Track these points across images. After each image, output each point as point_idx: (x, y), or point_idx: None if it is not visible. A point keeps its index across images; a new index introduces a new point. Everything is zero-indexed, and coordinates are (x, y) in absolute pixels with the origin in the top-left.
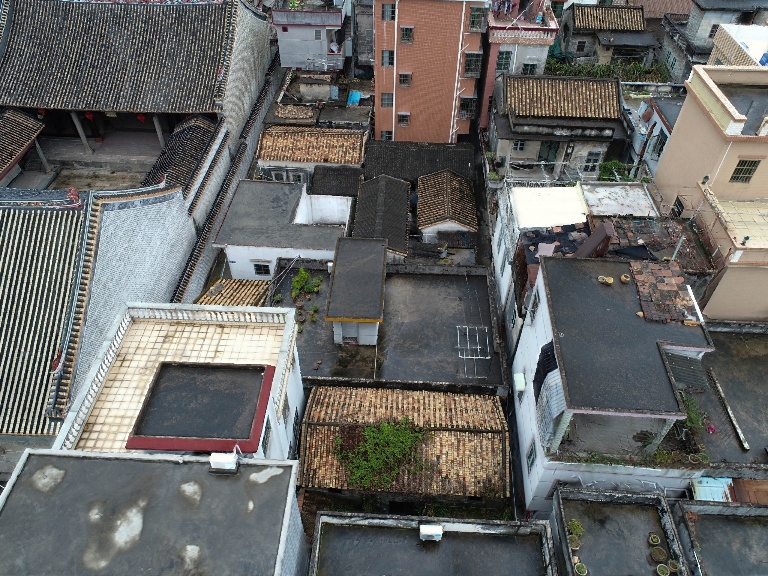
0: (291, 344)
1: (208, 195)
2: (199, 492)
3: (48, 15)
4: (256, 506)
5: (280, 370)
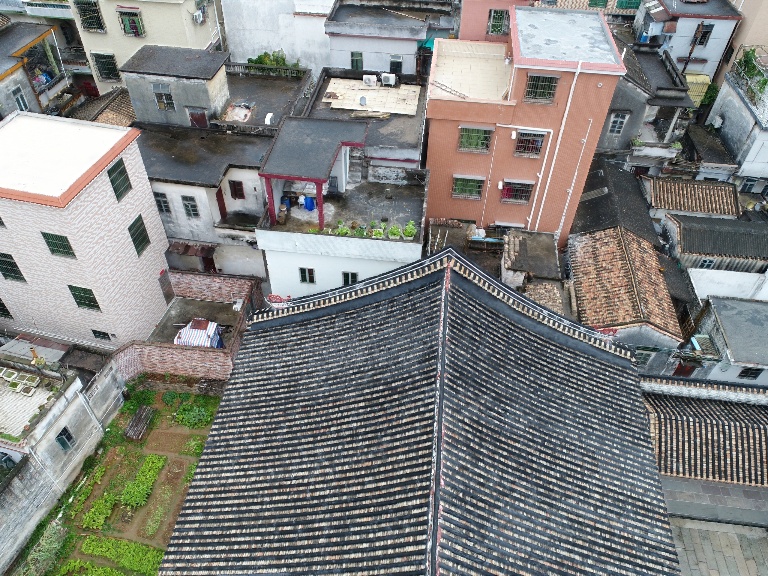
0: None
1: None
2: None
3: None
4: None
5: None
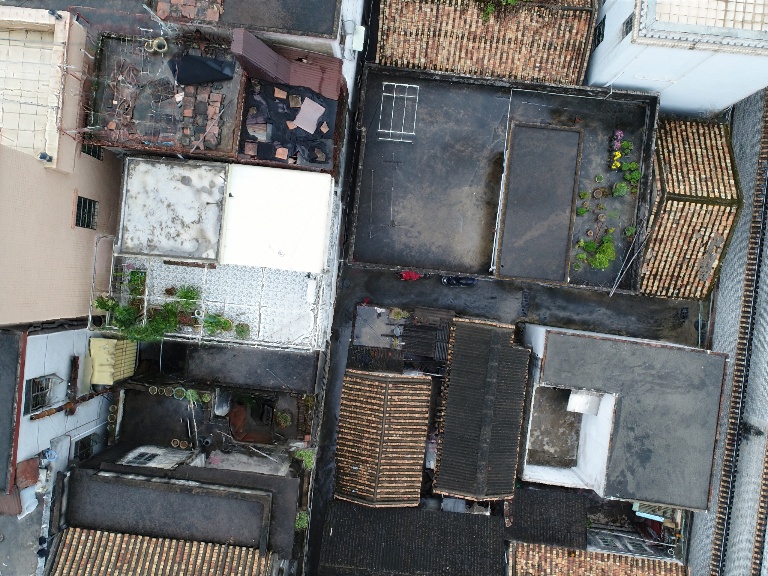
0: (642, 1)
1: (747, 503)
2: None
3: None
4: None
5: None
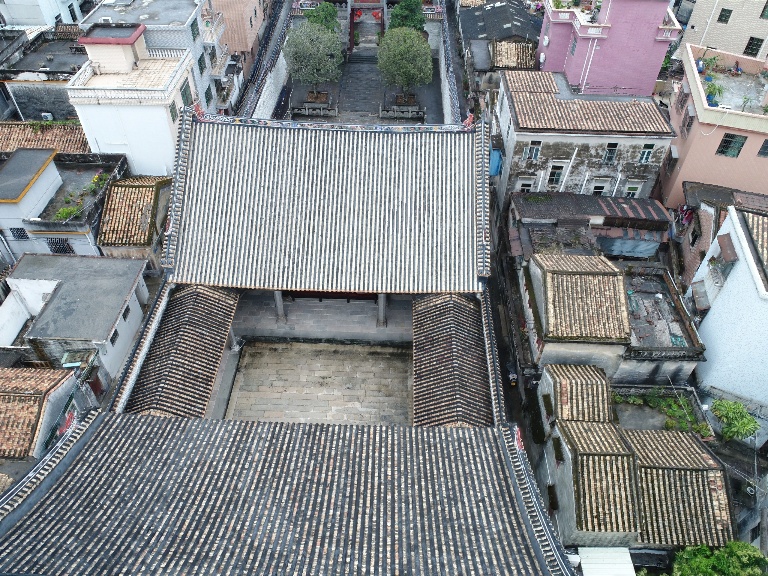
0: None
1: None
2: (119, 21)
3: (451, 569)
4: (98, 19)
5: (82, 68)
